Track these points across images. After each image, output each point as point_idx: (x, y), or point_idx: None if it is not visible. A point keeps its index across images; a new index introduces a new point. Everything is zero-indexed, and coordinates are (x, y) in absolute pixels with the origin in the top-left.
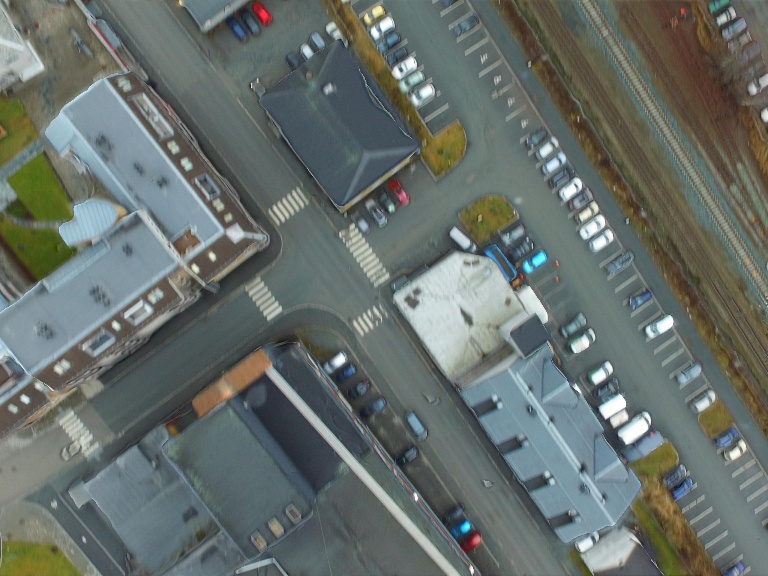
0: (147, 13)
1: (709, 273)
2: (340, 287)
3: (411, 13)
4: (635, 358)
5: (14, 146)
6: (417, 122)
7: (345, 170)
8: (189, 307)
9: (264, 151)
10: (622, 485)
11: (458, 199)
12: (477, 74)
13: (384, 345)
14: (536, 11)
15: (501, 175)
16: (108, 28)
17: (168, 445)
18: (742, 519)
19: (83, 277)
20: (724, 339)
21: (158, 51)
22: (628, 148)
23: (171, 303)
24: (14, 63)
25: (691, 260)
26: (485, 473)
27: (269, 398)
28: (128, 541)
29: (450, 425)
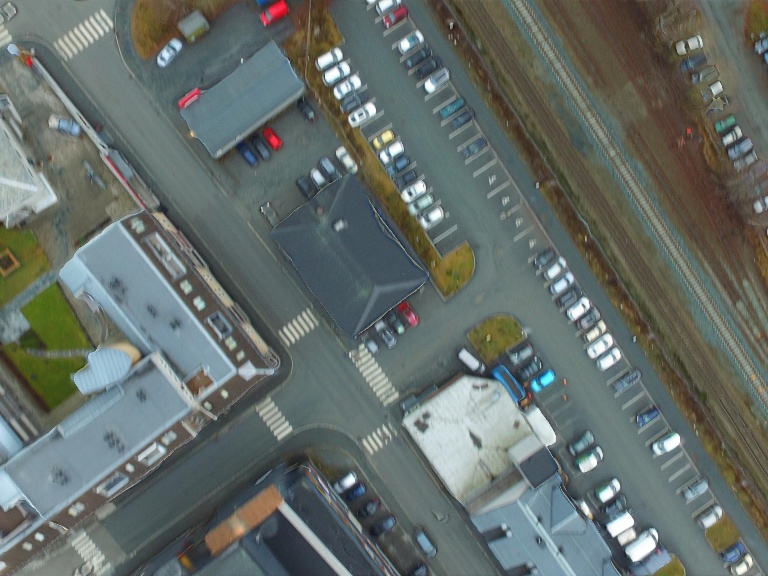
0: (158, 140)
1: (715, 389)
2: (350, 407)
3: (420, 136)
4: (642, 474)
5: (27, 276)
6: (426, 244)
7: (356, 304)
8: None
9: (274, 273)
10: None
11: (467, 319)
12: (485, 195)
13: (393, 463)
14: (544, 132)
15: (509, 295)
16: (120, 159)
17: None
18: None
19: (97, 423)
20: (730, 454)
21: (169, 177)
22: (635, 267)
23: (184, 442)
24: (28, 200)
25: (698, 376)
26: None
27: (281, 530)
28: None
29: (459, 542)
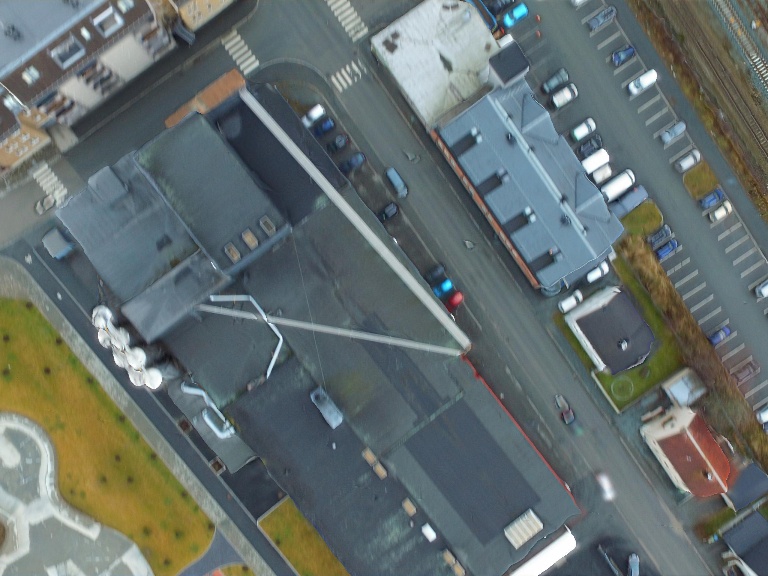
0: None
1: (693, 31)
2: (318, 41)
3: None
4: (618, 116)
5: None
6: None
7: None
8: (164, 56)
9: None
10: (604, 224)
11: None
12: None
13: (363, 101)
14: None
15: None
16: None
17: (139, 152)
18: (728, 283)
19: None
20: (709, 98)
21: None
22: None
23: (142, 17)
24: None
25: (675, 17)
26: (467, 233)
27: (244, 127)
28: (101, 268)
29: (431, 184)
